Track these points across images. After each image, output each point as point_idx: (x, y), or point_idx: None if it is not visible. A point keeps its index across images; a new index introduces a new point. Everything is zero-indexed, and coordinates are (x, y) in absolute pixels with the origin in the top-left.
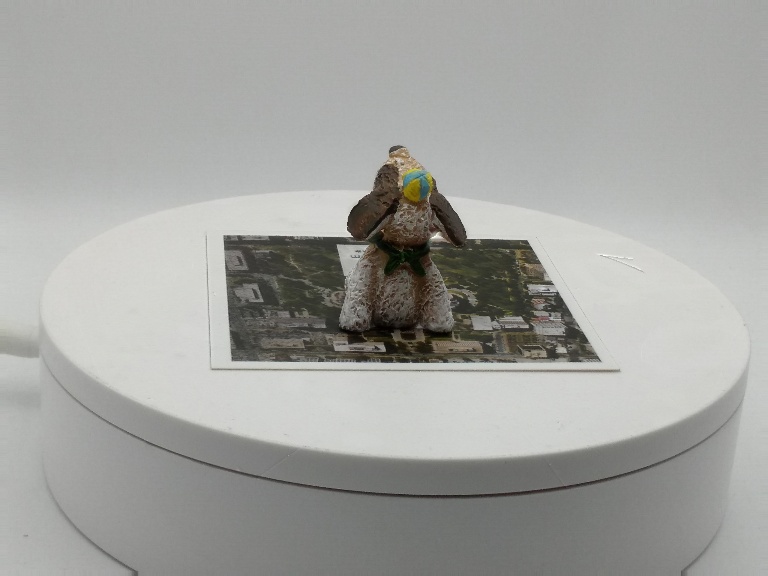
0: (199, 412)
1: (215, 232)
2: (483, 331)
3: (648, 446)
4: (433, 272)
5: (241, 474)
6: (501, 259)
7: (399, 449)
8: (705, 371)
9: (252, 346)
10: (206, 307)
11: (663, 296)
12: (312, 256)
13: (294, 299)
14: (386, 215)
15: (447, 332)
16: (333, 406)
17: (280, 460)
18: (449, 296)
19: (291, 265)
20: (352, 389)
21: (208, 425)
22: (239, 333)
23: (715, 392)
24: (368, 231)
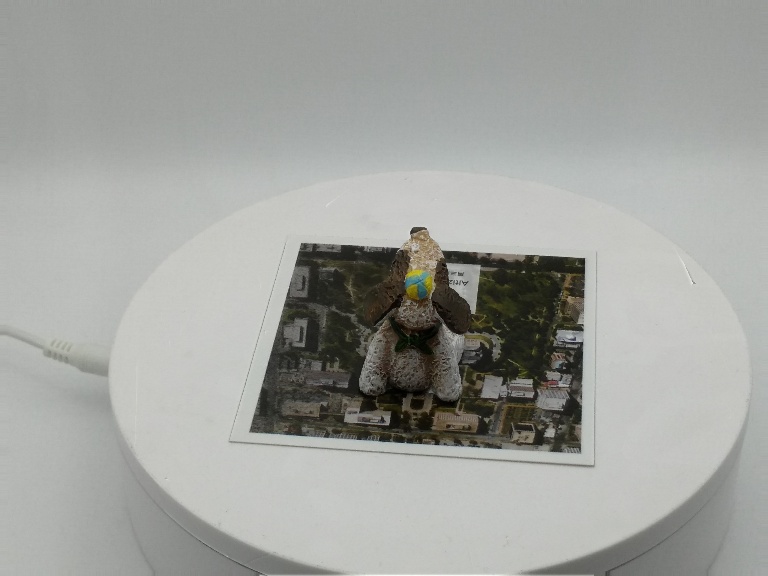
0: (201, 500)
1: (295, 238)
2: (488, 400)
3: (585, 565)
4: (440, 350)
5: (229, 560)
6: (547, 289)
7: (353, 562)
8: (677, 470)
9: (273, 412)
10: (253, 351)
11: (684, 352)
12: (371, 278)
13: (333, 344)
14: (391, 309)
15: (453, 401)
16: (316, 499)
17: (257, 557)
18: (476, 345)
19: (347, 292)
20: (341, 477)
21: (203, 518)
22: (268, 392)
23: (673, 501)
24: (375, 321)
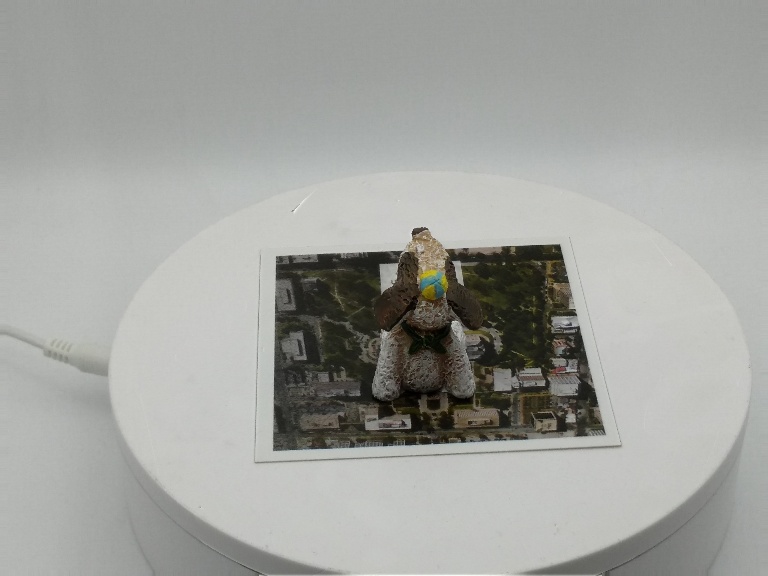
0: (242, 524)
1: (269, 252)
2: (502, 393)
3: (635, 544)
4: (454, 348)
5: None
6: (531, 278)
7: (411, 568)
8: (701, 441)
9: (292, 427)
10: (255, 369)
11: (678, 326)
12: (355, 285)
13: (334, 353)
14: (406, 312)
15: (469, 398)
16: (358, 510)
17: (310, 575)
18: (477, 340)
19: (335, 300)
20: (377, 485)
21: (248, 542)
22: (282, 408)
23: (705, 471)
24: (391, 325)
